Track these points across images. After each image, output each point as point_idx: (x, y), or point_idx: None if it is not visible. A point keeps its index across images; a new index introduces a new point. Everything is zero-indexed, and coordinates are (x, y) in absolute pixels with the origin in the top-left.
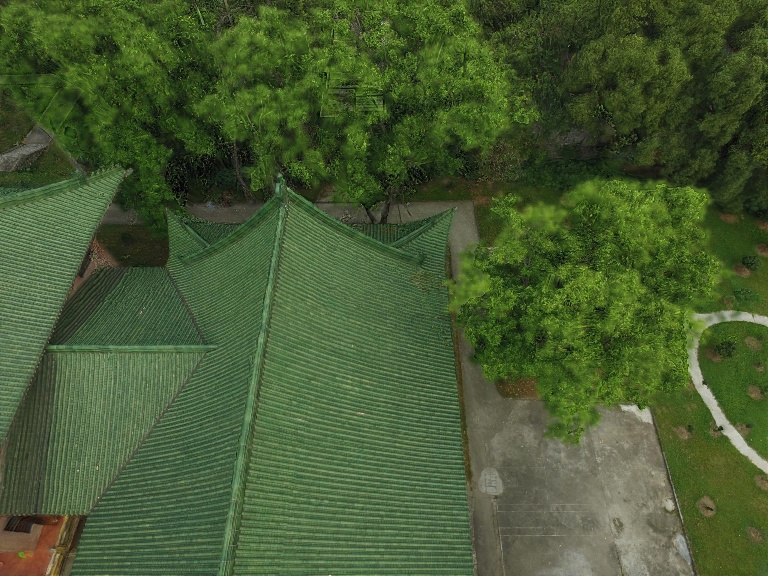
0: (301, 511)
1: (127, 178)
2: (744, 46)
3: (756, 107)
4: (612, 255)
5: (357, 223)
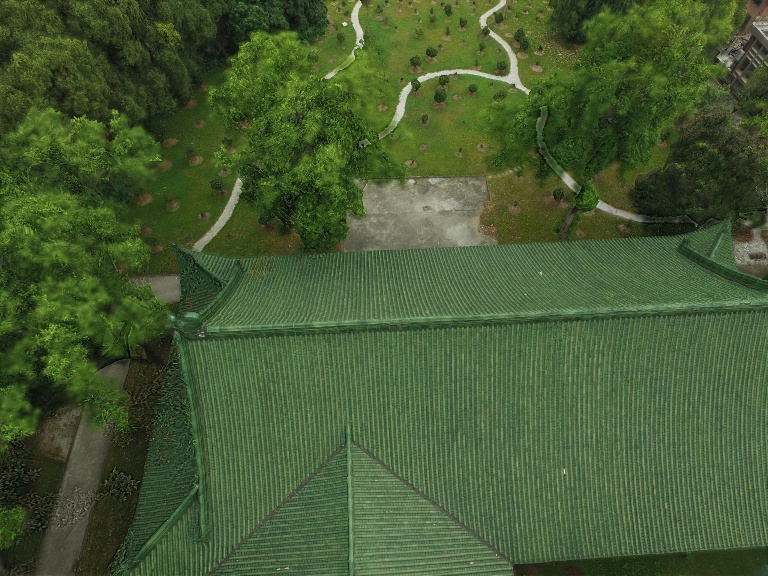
0: (494, 306)
1: None
2: (66, 3)
3: (132, 23)
4: (292, 98)
5: None
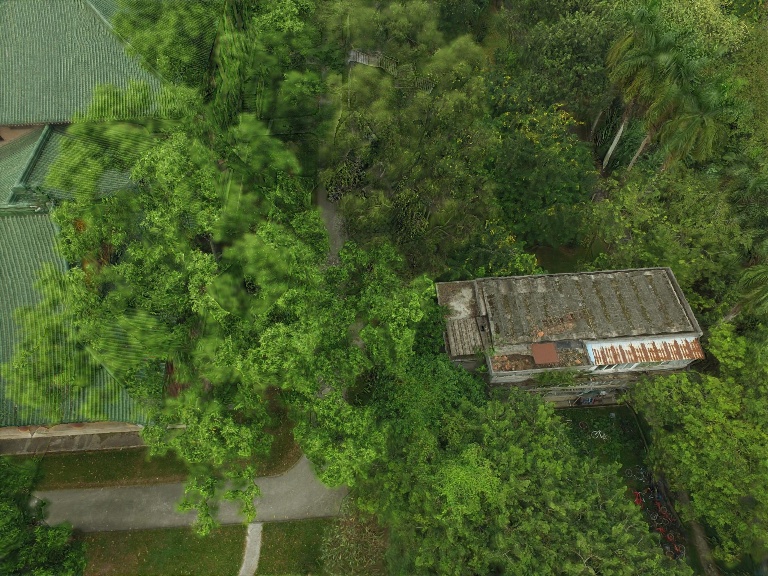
0: None
1: None
2: None
3: None
4: None
5: None
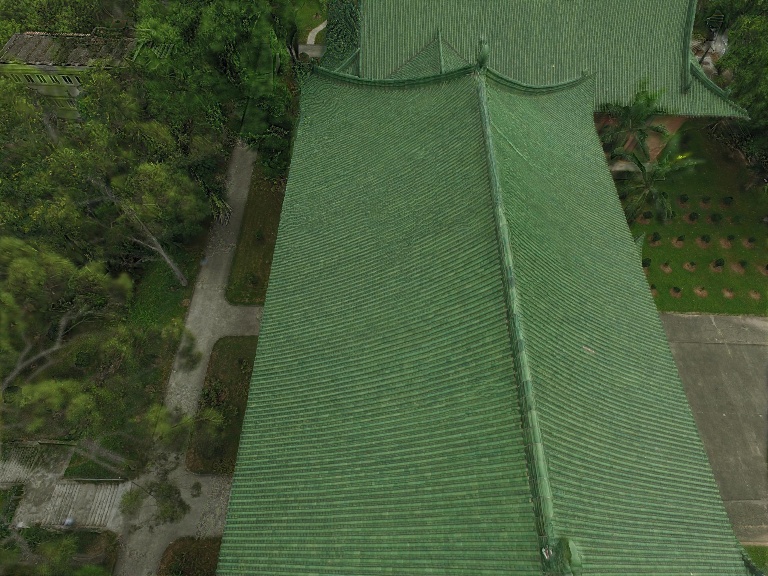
0: None
1: (198, 215)
2: None
3: None
4: None
5: (271, 99)
